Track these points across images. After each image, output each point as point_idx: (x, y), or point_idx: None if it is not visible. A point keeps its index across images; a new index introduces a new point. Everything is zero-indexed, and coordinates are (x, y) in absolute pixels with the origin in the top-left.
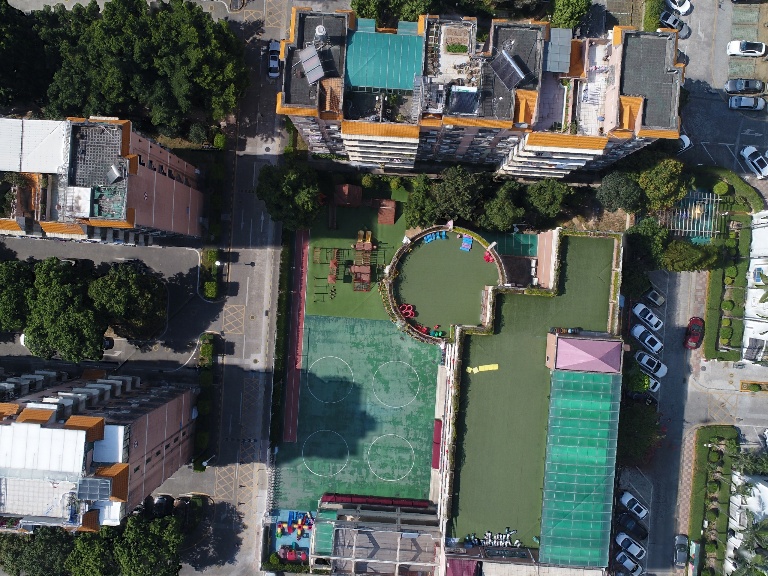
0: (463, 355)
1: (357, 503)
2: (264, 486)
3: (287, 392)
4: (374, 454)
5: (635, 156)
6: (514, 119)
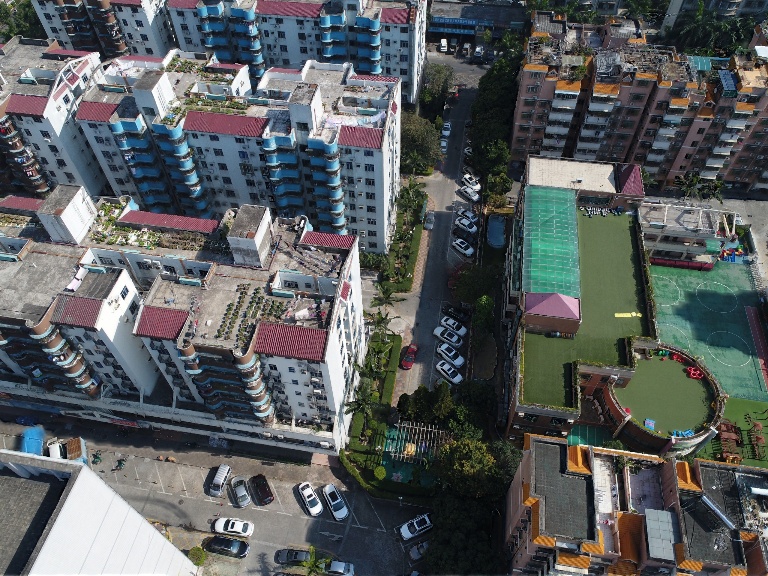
0: (647, 326)
1: (684, 261)
2: (762, 279)
3: (765, 342)
4: (675, 294)
5: (491, 491)
6: (692, 469)
